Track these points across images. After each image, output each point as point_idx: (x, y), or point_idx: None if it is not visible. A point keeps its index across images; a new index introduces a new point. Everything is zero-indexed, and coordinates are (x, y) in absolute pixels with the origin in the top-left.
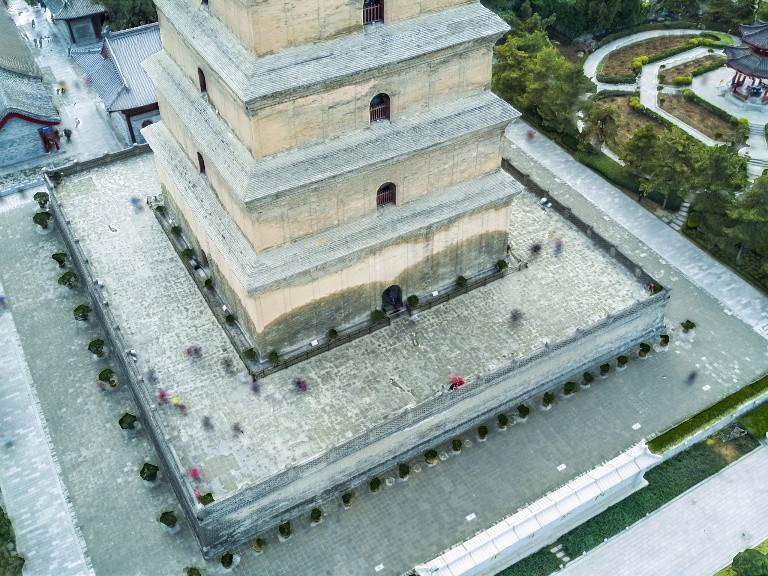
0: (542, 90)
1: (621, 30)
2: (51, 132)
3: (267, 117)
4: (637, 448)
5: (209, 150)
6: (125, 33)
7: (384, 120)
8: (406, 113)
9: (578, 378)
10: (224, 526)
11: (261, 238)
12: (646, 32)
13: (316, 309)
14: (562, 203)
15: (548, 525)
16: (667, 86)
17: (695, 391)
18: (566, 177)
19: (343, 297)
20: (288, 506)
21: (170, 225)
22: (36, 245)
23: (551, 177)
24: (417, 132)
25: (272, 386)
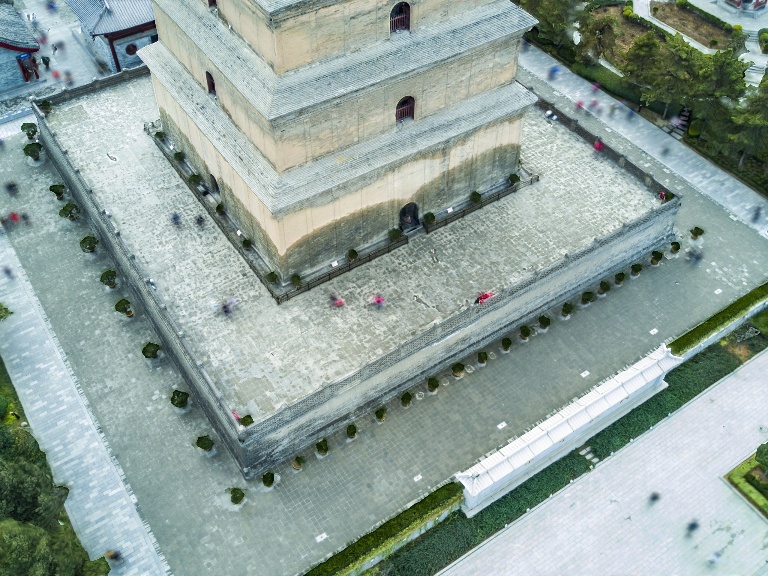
0: (537, 1)
1: None
2: (28, 60)
3: (290, 29)
4: (659, 351)
5: (224, 67)
6: None
7: (403, 31)
8: (425, 23)
9: (594, 288)
10: (263, 446)
11: (283, 157)
12: None
13: (336, 229)
14: None
15: (578, 429)
16: None
17: (707, 295)
18: (565, 90)
19: (362, 216)
20: (323, 424)
21: (171, 151)
22: (30, 178)
23: (550, 90)
24: (437, 42)
25: (297, 308)
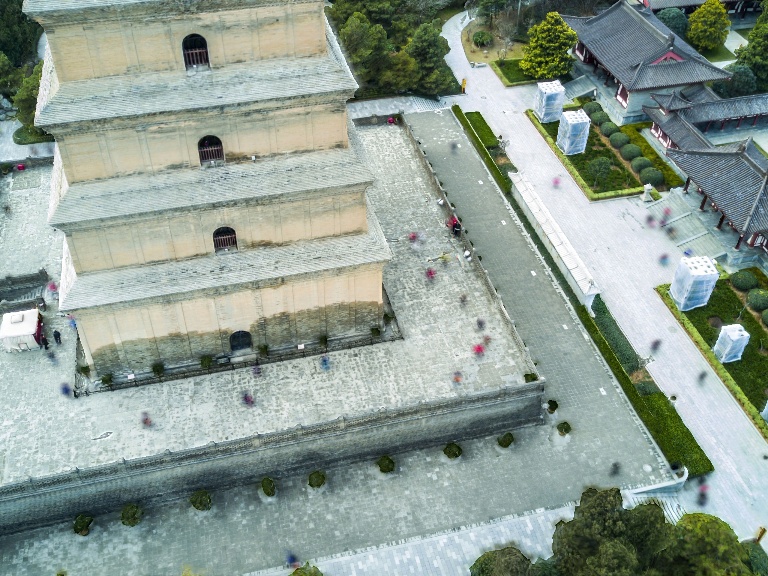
0: None
1: None
2: None
3: None
4: (514, 177)
5: (283, 188)
6: None
7: None
8: None
9: None
10: None
11: None
12: (44, 36)
13: None
14: None
15: None
16: None
17: (461, 151)
18: None
19: None
20: None
21: (136, 379)
22: (15, 568)
23: None
24: None
25: (413, 330)
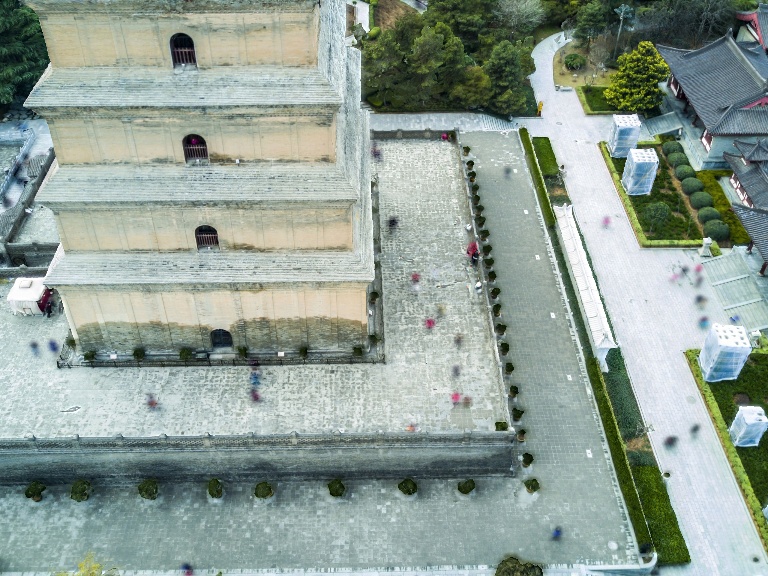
0: None
1: None
2: None
3: None
4: (558, 211)
5: (262, 195)
6: None
7: None
8: None
9: None
10: None
11: None
12: None
13: None
14: None
15: None
16: None
17: (515, 176)
18: None
19: None
20: None
21: (118, 360)
22: None
23: None
24: (350, 92)
25: (398, 355)
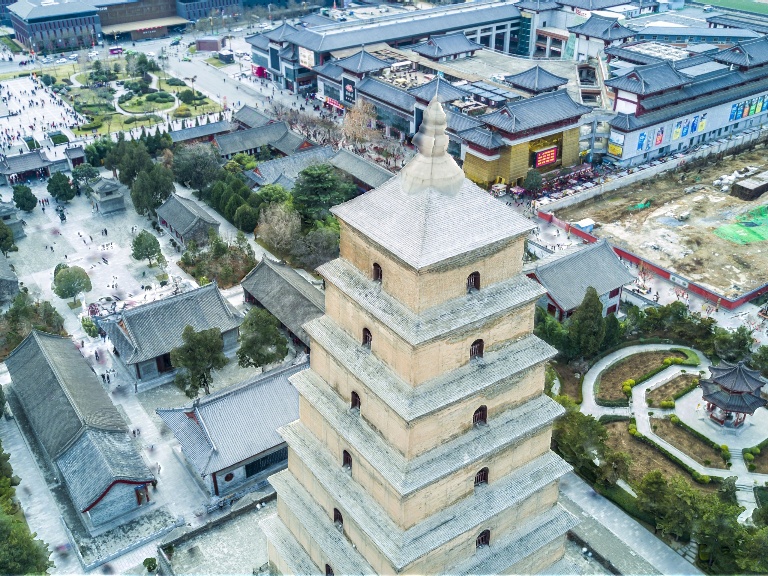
0: (560, 429)
1: (605, 347)
2: None
3: (409, 569)
4: None
5: None
6: (211, 401)
7: (485, 545)
8: (500, 537)
9: None
10: None
11: None
12: (626, 349)
13: None
14: (593, 539)
15: None
16: (655, 409)
17: None
18: (591, 510)
19: None
20: None
21: None
22: None
23: (579, 511)
24: (509, 551)
25: None
